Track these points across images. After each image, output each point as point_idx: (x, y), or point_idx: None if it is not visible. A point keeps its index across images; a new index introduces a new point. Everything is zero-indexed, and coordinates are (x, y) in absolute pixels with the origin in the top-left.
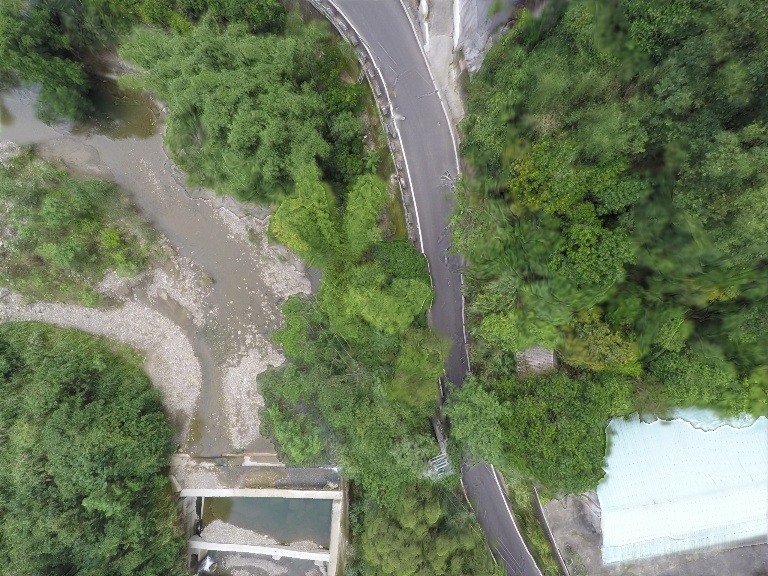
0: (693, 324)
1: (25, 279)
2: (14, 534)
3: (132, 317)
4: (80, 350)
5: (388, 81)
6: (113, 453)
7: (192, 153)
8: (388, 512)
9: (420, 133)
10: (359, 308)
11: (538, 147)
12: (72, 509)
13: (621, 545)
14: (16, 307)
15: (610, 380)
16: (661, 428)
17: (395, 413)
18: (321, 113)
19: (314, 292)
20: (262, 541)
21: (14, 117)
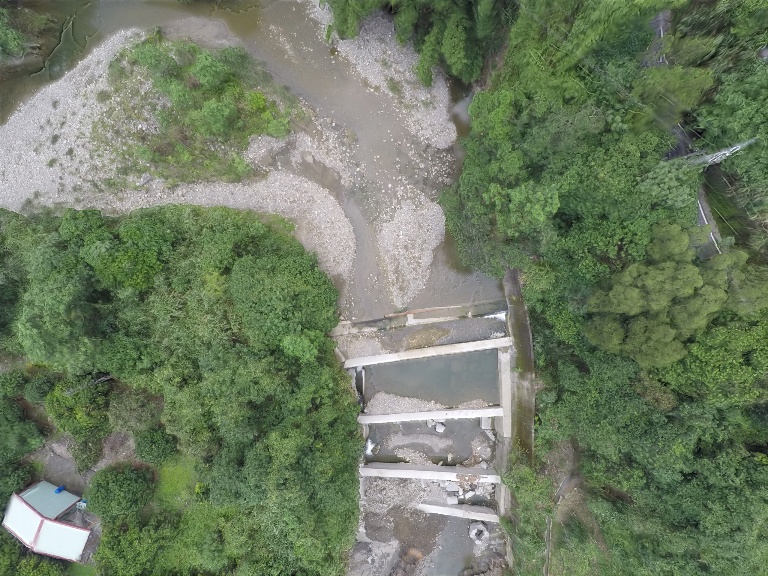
0: None
1: (171, 155)
2: (217, 385)
3: (278, 186)
4: (235, 220)
5: None
6: (296, 302)
7: None
8: None
9: None
10: (625, 7)
11: None
12: (269, 356)
13: None
14: (158, 193)
15: None
16: None
17: (639, 151)
18: None
19: (460, 135)
20: (430, 407)
21: (133, 5)
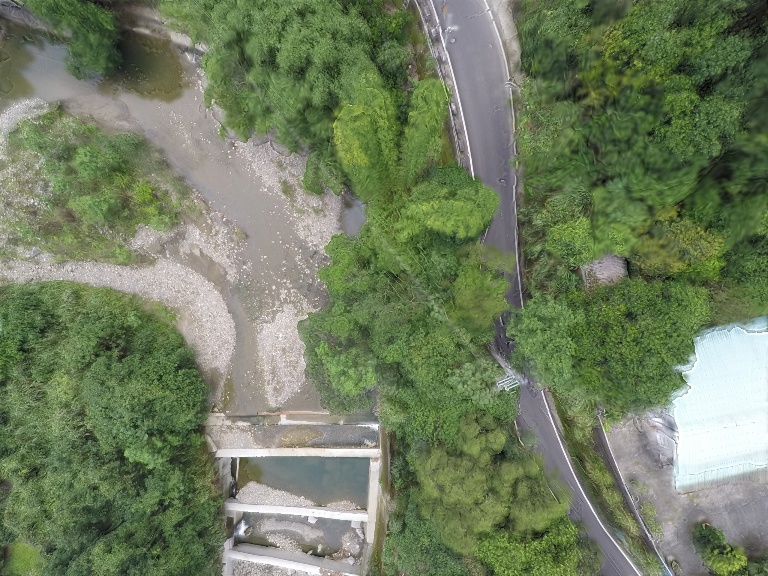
0: None
1: (57, 236)
2: (56, 486)
3: (165, 274)
4: (114, 307)
5: (437, 2)
6: (152, 406)
7: (231, 88)
8: (445, 449)
9: (471, 56)
10: (422, 222)
11: (641, 4)
12: (113, 461)
13: (698, 473)
14: (48, 267)
15: (693, 290)
16: (741, 348)
17: (453, 343)
18: (366, 38)
19: None
20: (299, 502)
21: (41, 73)
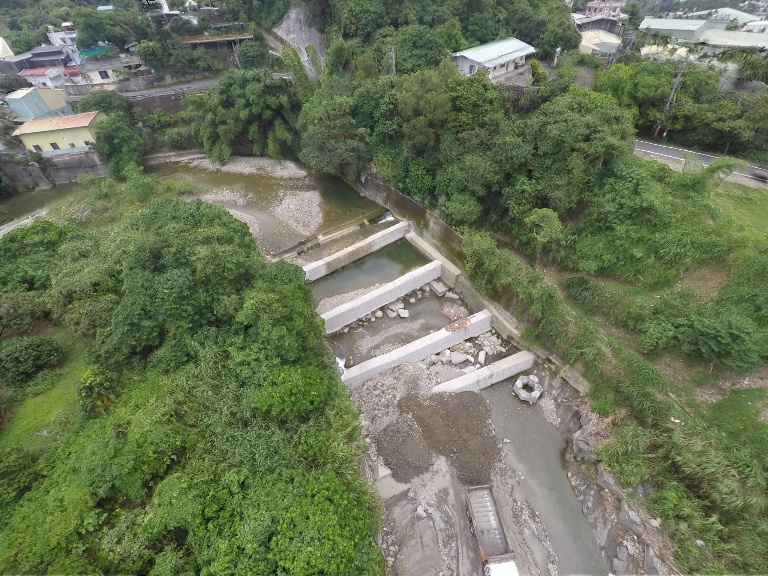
0: (421, 24)
1: None
2: None
3: None
4: None
5: None
6: None
7: None
8: None
9: None
10: None
11: None
12: None
13: (486, 61)
14: None
15: None
16: None
17: None
18: None
19: (309, 173)
20: (376, 288)
21: None
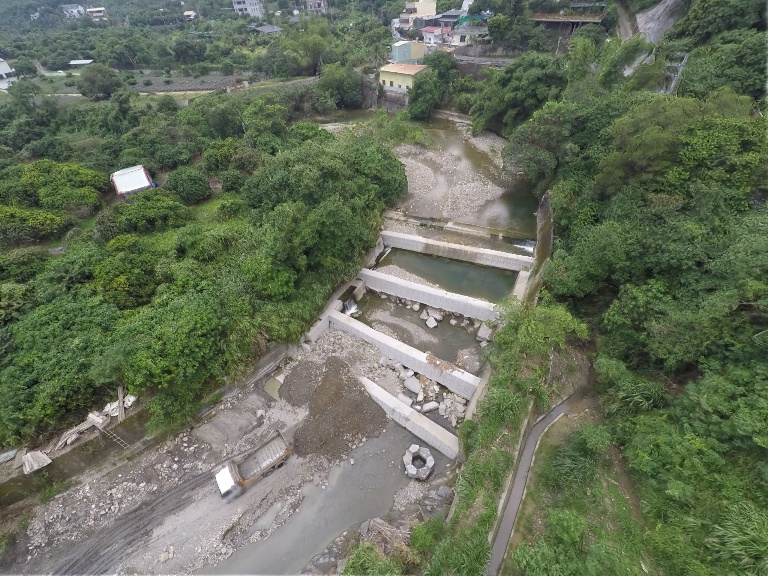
0: None
1: None
2: None
3: None
4: None
5: None
6: None
7: None
8: None
9: None
10: None
11: None
12: None
13: None
14: None
15: None
16: None
17: None
18: None
19: None
20: (433, 287)
21: None
